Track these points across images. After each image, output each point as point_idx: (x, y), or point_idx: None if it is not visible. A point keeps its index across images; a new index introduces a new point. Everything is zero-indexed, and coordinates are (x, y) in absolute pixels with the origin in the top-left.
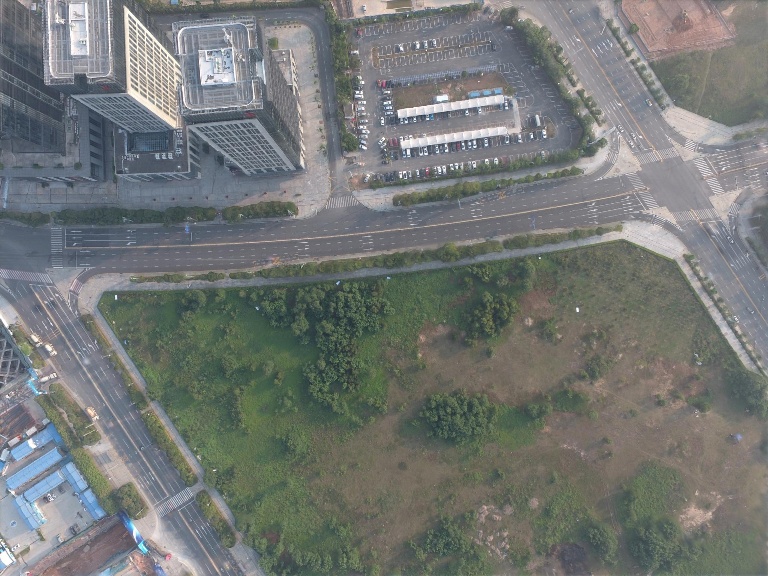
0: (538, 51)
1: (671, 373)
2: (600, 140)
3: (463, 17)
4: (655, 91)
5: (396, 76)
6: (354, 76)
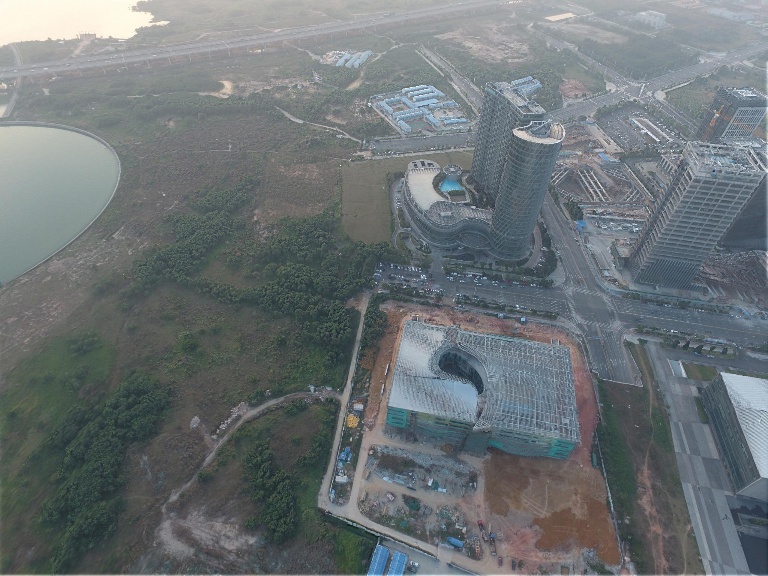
0: (610, 109)
1: (709, 93)
2: (635, 100)
3: (602, 128)
4: (605, 92)
5: (640, 143)
6: (654, 148)
